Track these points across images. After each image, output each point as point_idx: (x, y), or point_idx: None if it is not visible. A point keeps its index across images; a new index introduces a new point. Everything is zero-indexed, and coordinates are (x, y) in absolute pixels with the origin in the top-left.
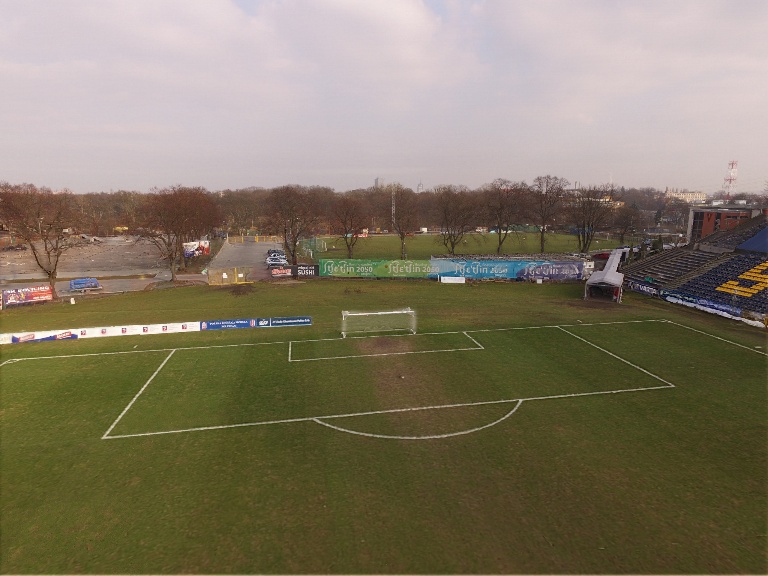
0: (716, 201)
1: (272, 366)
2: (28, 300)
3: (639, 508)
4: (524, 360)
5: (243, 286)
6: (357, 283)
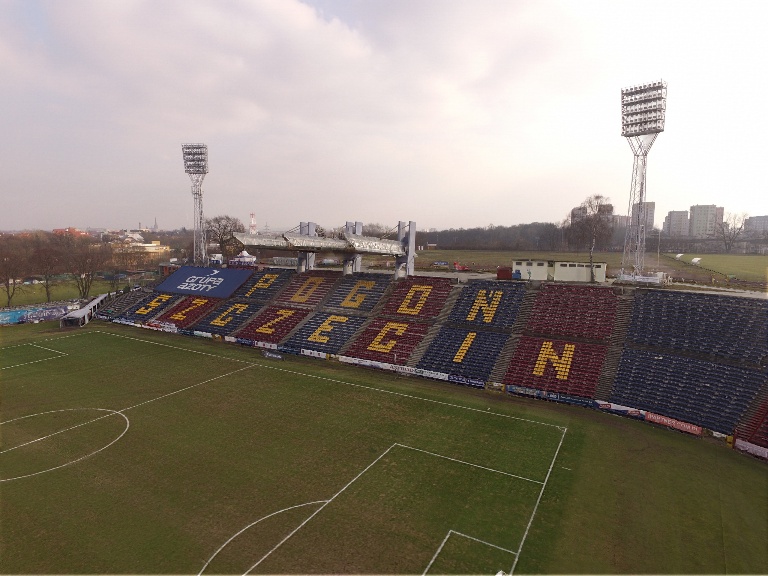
0: (172, 259)
1: None
2: None
3: None
4: None
5: None
6: None
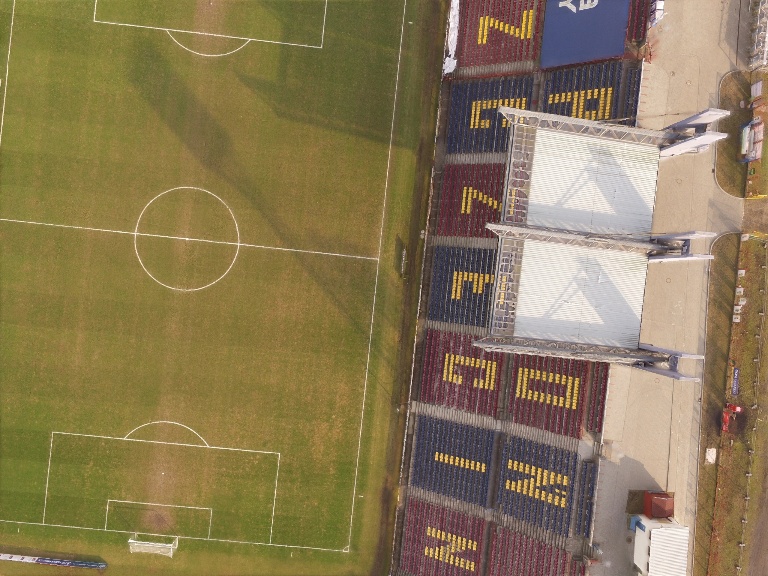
0: None
1: None
2: None
3: (243, 104)
4: (277, 2)
5: None
6: None
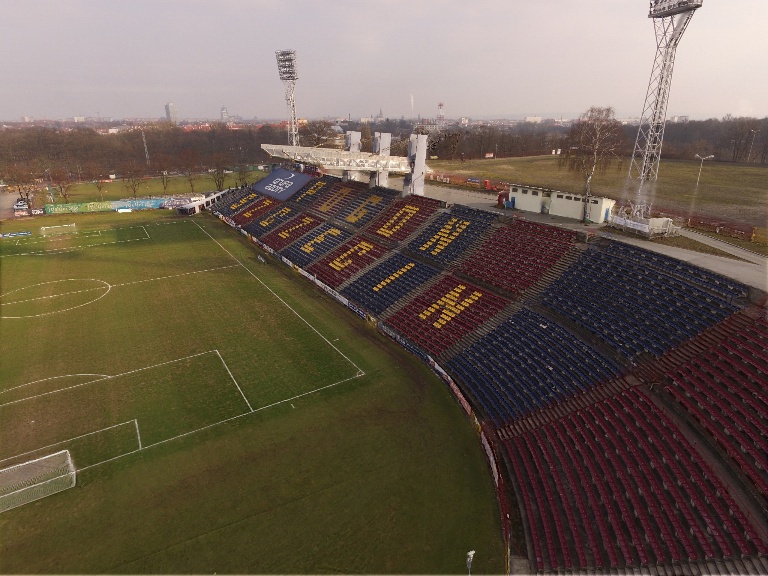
0: None
1: (9, 246)
2: None
3: None
4: None
5: None
6: (69, 216)
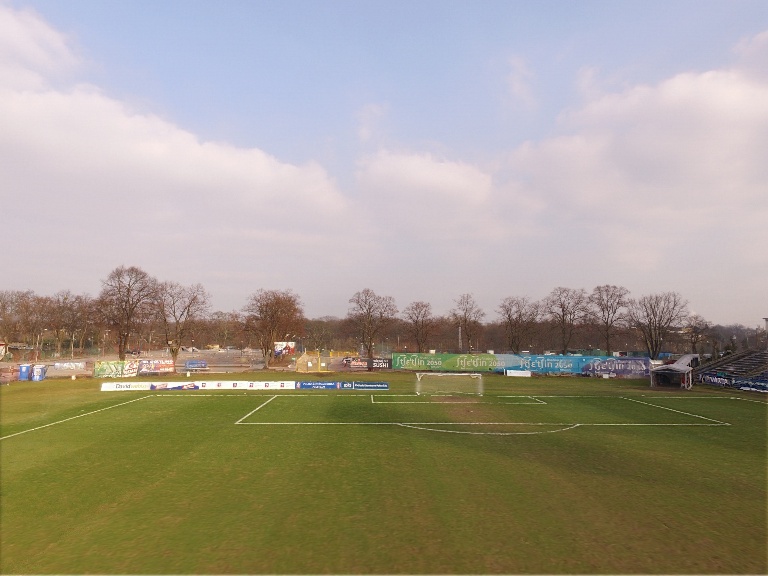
0: None
1: (359, 403)
2: (156, 370)
3: (677, 465)
4: (584, 409)
5: (325, 373)
6: None
